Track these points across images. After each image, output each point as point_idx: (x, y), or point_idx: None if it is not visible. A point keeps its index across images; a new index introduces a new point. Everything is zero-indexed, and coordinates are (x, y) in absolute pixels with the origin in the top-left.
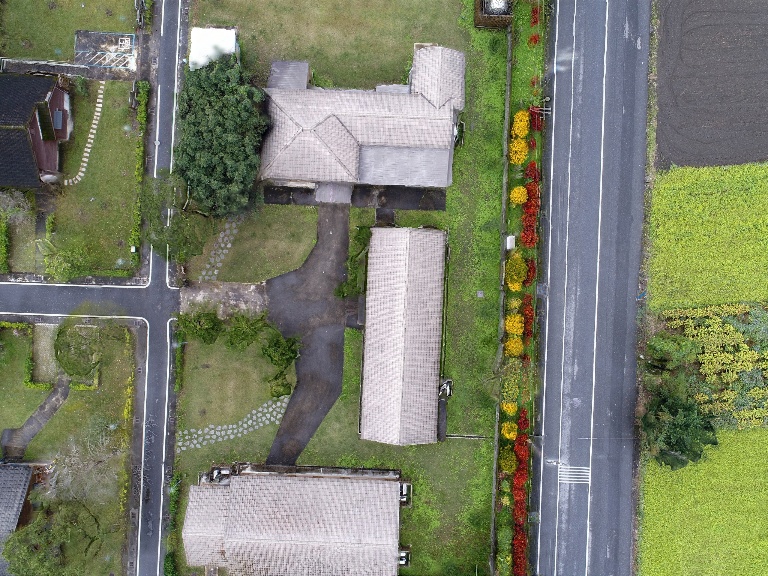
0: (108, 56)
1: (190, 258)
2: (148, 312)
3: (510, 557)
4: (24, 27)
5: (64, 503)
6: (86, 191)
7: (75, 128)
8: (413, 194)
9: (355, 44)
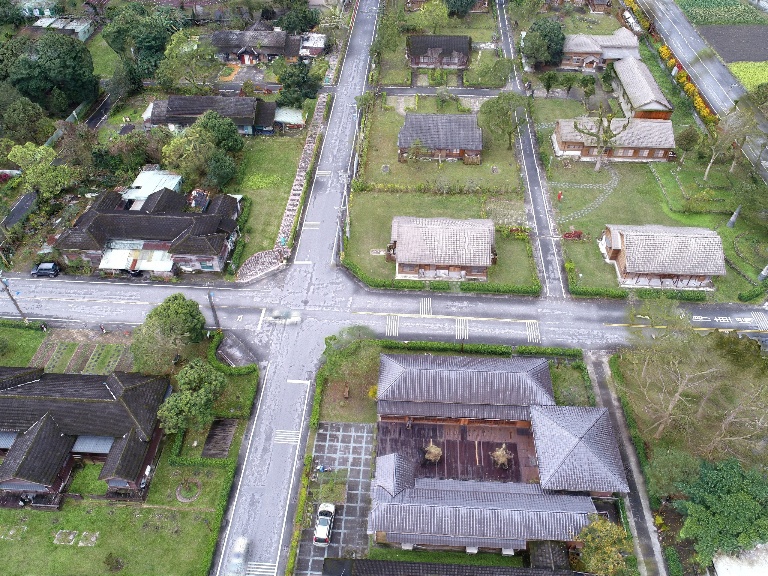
0: (482, 45)
1: None
2: None
3: None
4: None
5: None
6: None
7: None
8: None
9: None
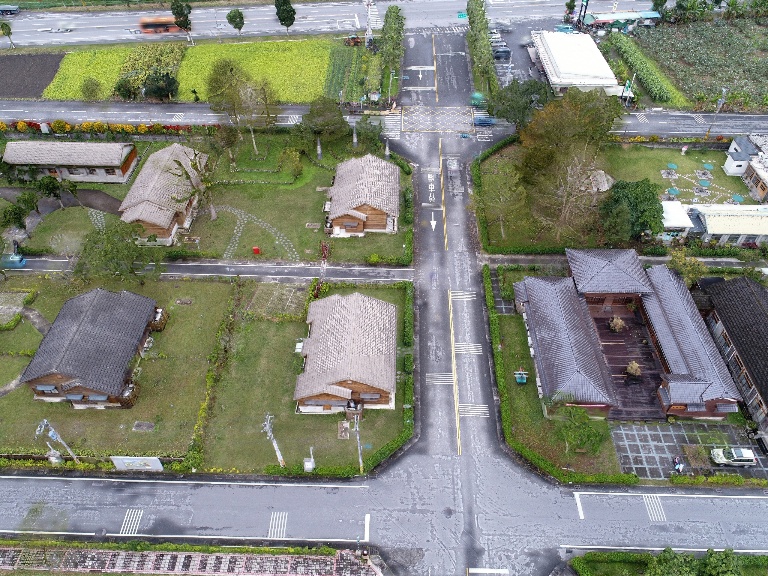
0: None
1: None
2: None
3: None
4: None
5: None
6: None
7: None
8: None
9: None
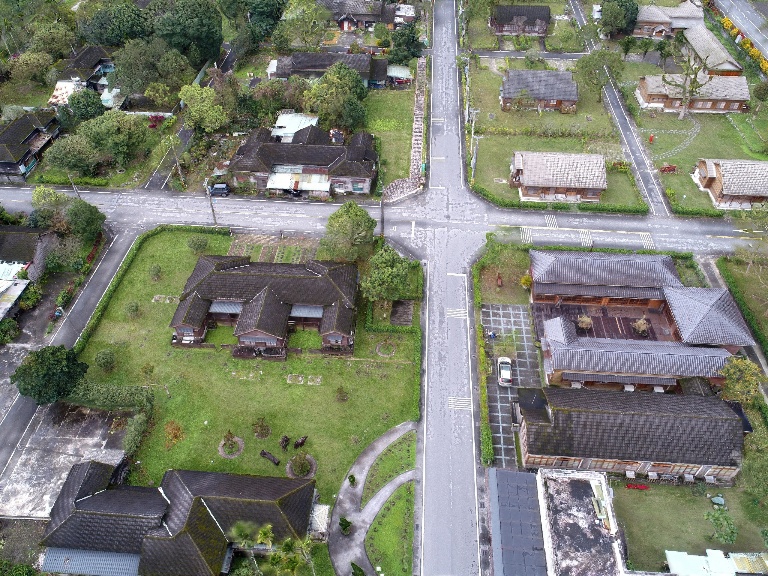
0: None
1: None
2: None
3: None
4: None
5: None
6: None
7: None
8: None
9: None
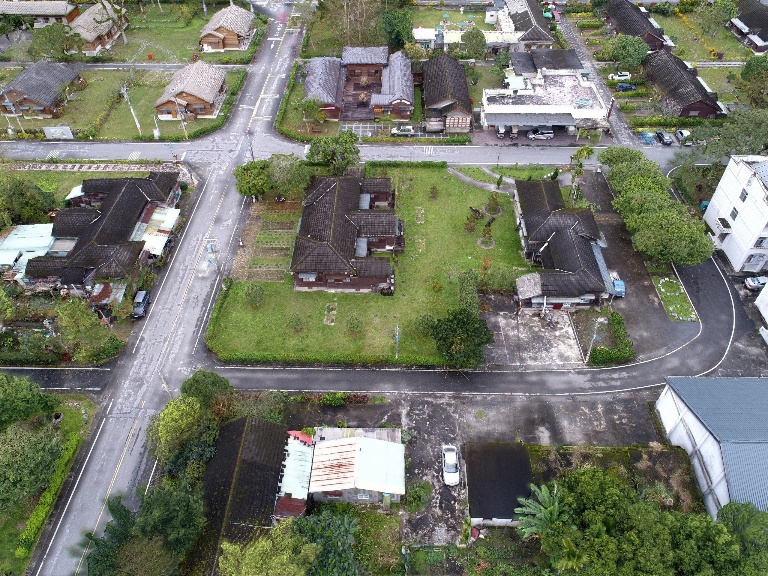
0: None
1: None
2: None
3: None
4: None
5: None
6: None
7: None
8: None
9: None
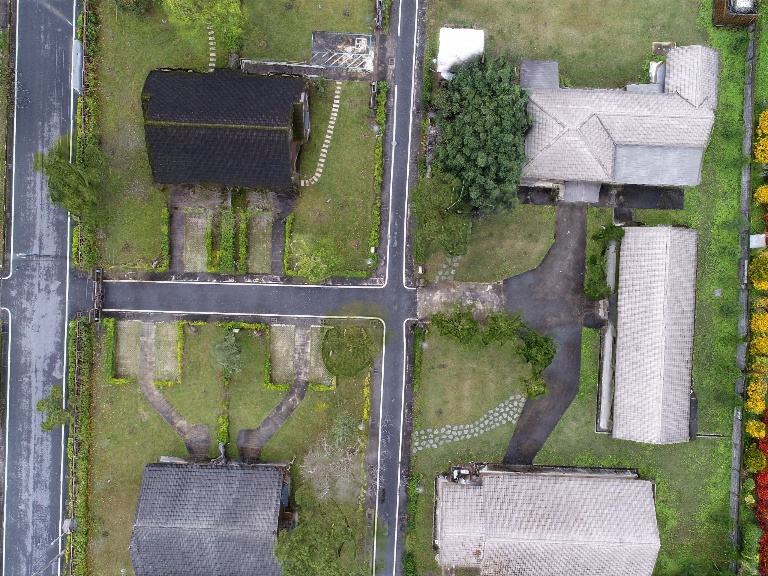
0: (345, 57)
1: (428, 258)
2: (384, 312)
3: (758, 555)
4: (261, 28)
5: (326, 503)
6: (323, 192)
7: (312, 129)
8: (651, 193)
9: (593, 43)
